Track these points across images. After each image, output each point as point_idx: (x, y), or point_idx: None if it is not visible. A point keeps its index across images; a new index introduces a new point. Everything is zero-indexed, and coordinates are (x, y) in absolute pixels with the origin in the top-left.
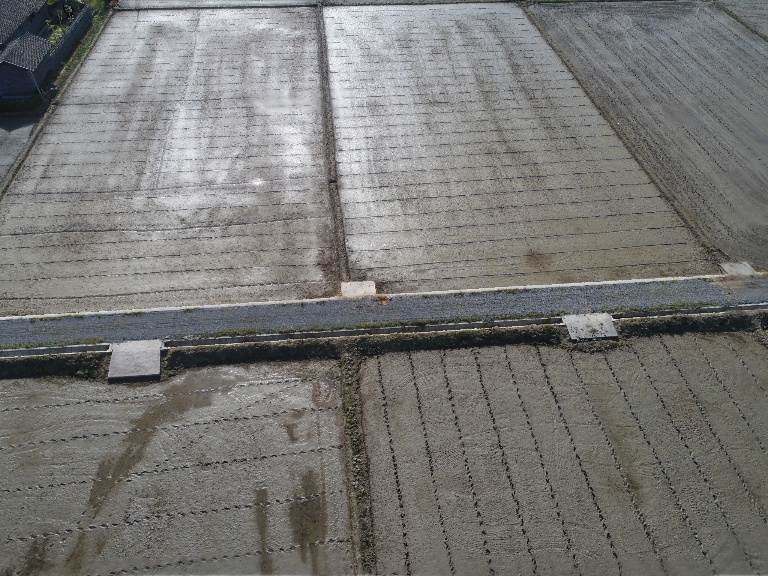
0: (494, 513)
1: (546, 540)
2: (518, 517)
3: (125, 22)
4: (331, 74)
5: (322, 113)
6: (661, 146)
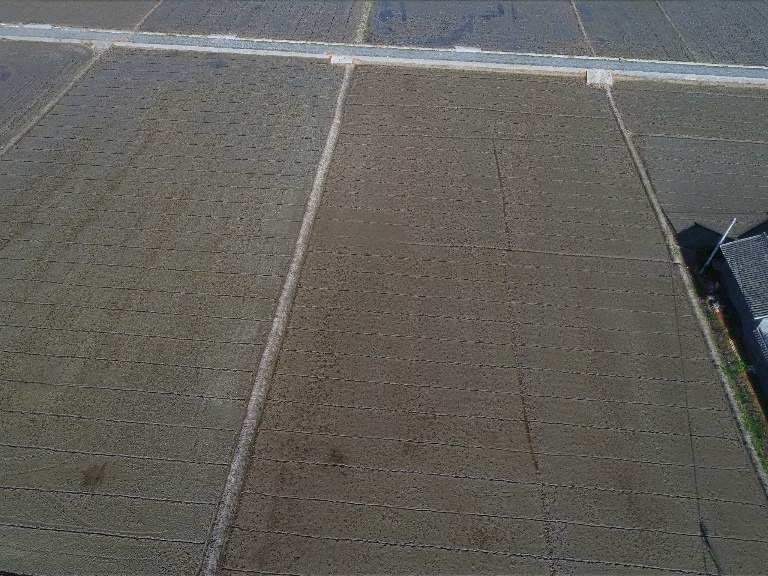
0: (316, 8)
1: (301, 3)
2: (308, 7)
3: (751, 575)
4: (283, 272)
5: (320, 205)
6: (5, 119)
